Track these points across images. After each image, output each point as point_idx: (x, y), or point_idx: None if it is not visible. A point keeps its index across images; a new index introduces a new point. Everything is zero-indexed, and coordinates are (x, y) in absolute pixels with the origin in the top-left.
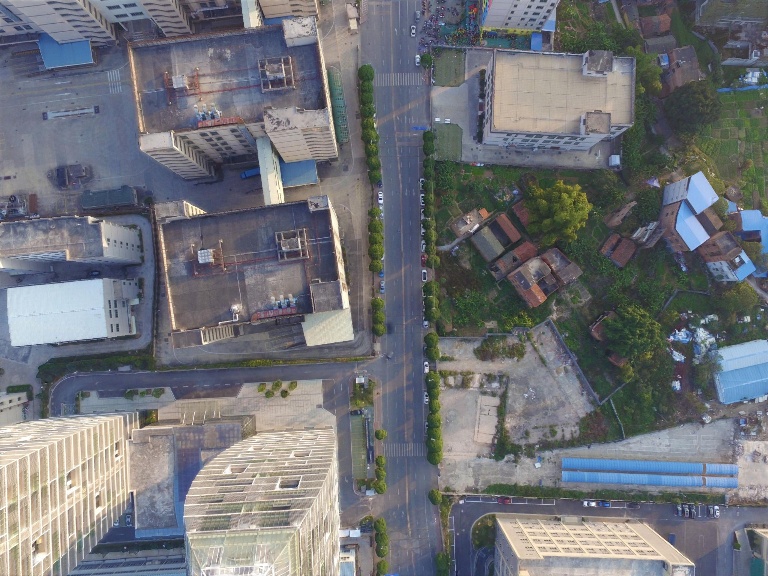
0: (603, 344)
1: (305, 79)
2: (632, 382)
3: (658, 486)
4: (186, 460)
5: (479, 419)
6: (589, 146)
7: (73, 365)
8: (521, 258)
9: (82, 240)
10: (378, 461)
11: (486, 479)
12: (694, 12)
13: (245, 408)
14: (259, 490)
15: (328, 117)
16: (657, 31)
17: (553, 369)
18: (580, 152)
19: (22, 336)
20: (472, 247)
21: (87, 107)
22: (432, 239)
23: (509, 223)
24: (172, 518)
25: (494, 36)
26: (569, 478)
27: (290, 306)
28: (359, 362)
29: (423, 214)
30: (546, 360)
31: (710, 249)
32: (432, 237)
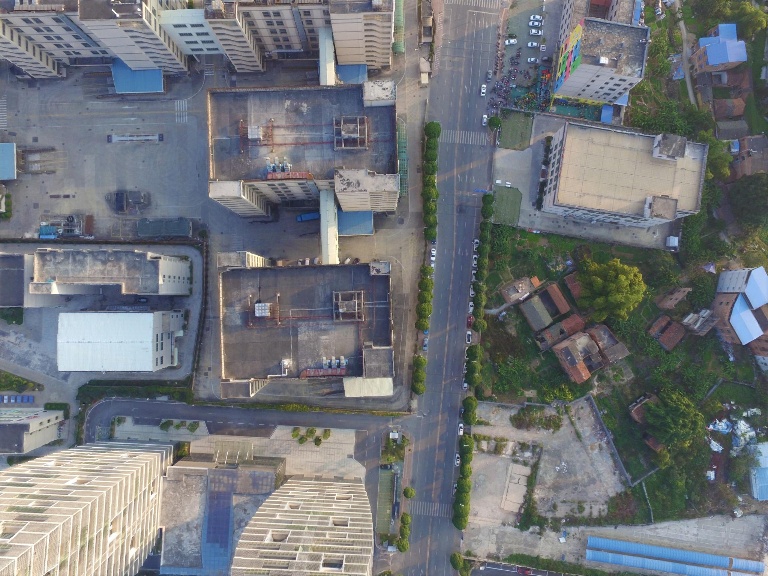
0: (641, 426)
1: (378, 140)
2: (666, 467)
3: (681, 574)
4: (217, 503)
5: (508, 487)
6: (649, 225)
7: (113, 391)
8: (568, 331)
9: (139, 275)
10: (404, 519)
11: (509, 548)
12: None
13: (277, 450)
14: (304, 569)
15: (398, 183)
16: (730, 115)
17: (588, 445)
18: (638, 229)
19: (69, 361)
20: (519, 314)
21: (152, 134)
22: (482, 304)
23: (560, 294)
24: (198, 558)
25: (564, 103)
26: (593, 557)
27: (340, 367)
28: (394, 416)
29: (474, 276)
30: (582, 435)
31: (762, 344)
32: (482, 302)
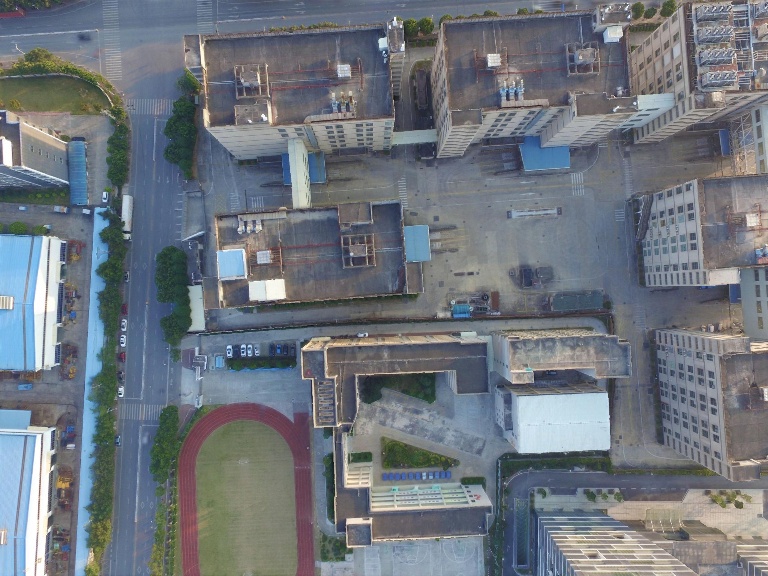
0: None
1: None
2: None
3: None
4: None
5: None
6: None
7: (541, 465)
8: None
9: (607, 358)
10: None
11: None
12: None
13: (690, 513)
14: None
15: None
16: None
17: None
18: None
19: (530, 444)
20: None
21: (550, 208)
22: None
23: None
24: None
25: None
26: None
27: None
28: None
29: None
30: None
31: None
32: None
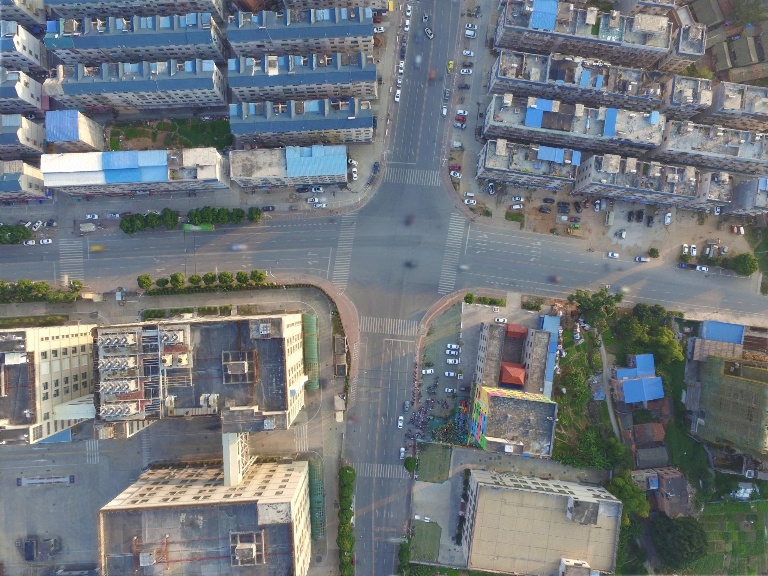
0: None
1: (276, 553)
2: None
3: None
4: None
5: None
6: None
7: None
8: None
9: None
10: None
11: None
12: (691, 418)
13: None
14: None
15: None
16: (650, 440)
17: None
18: None
19: None
20: None
21: (62, 476)
22: None
23: None
24: None
25: None
26: None
27: None
28: None
29: None
30: None
31: None
32: None
